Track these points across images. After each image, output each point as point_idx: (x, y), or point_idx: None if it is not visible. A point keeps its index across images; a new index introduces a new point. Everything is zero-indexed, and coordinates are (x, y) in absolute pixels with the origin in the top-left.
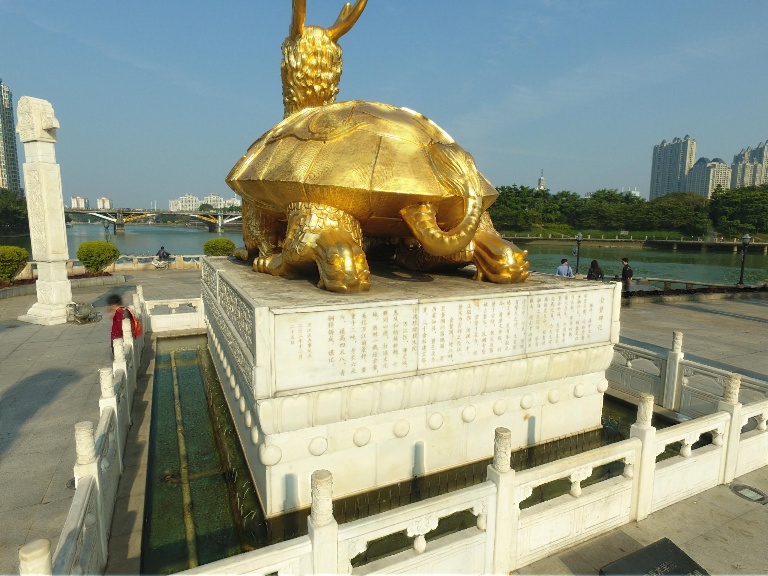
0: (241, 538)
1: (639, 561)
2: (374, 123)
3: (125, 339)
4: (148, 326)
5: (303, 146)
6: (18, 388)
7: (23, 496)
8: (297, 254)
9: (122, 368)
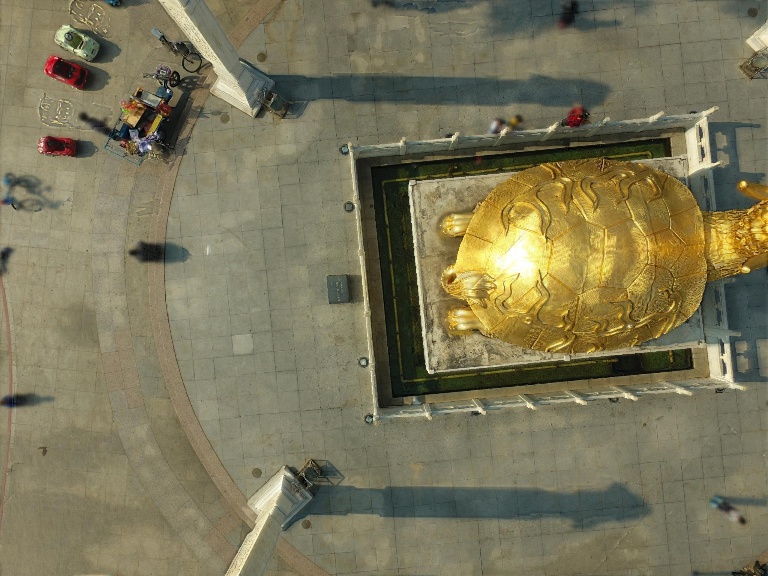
0: None
1: (345, 287)
2: (505, 241)
3: (551, 127)
4: (689, 127)
5: (507, 198)
6: (568, 79)
7: (446, 121)
8: None
9: None
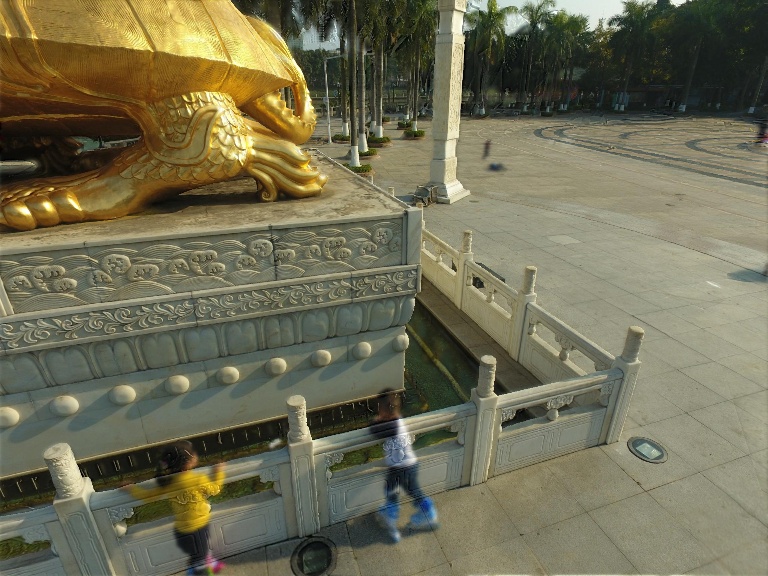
0: (414, 413)
1: None
2: None
3: None
4: None
5: None
6: None
7: None
8: (239, 166)
9: (91, 492)
